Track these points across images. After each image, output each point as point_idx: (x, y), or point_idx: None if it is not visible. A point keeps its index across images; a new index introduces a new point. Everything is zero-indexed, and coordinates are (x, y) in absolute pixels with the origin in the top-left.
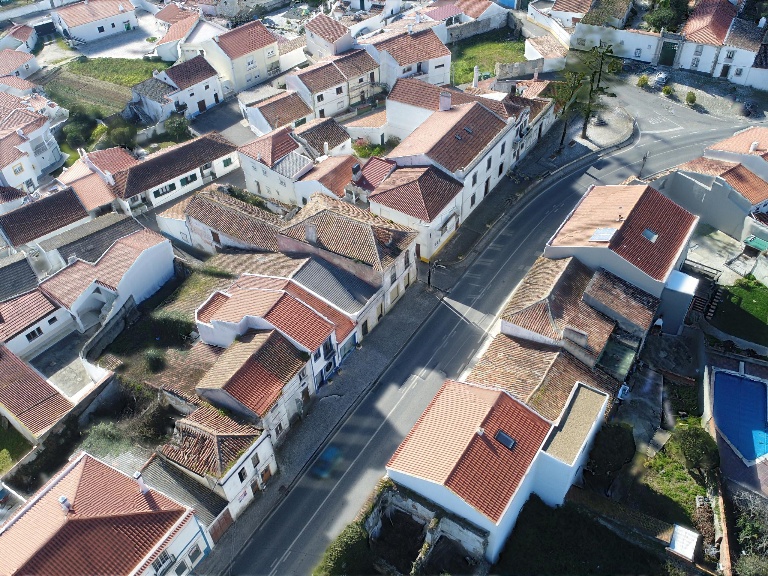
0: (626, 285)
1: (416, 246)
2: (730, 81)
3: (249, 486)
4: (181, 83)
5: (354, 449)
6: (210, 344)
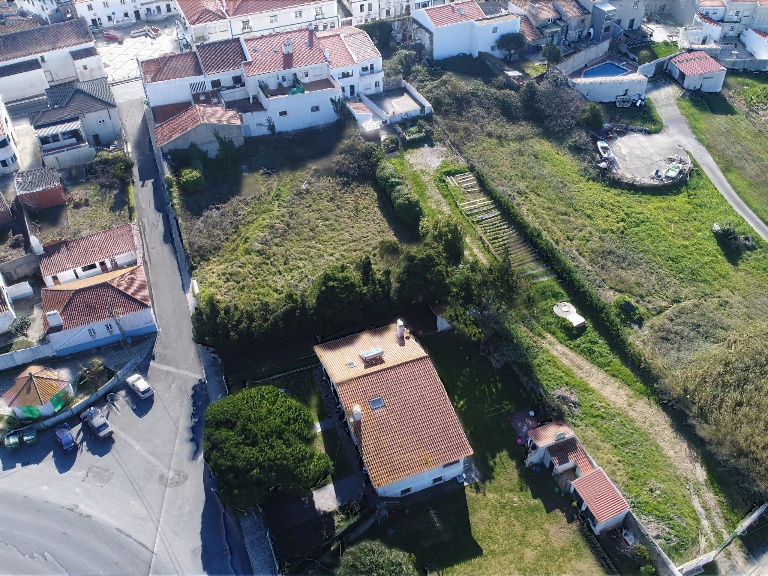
0: (579, 3)
1: None
2: None
3: (364, 19)
4: None
5: None
6: None
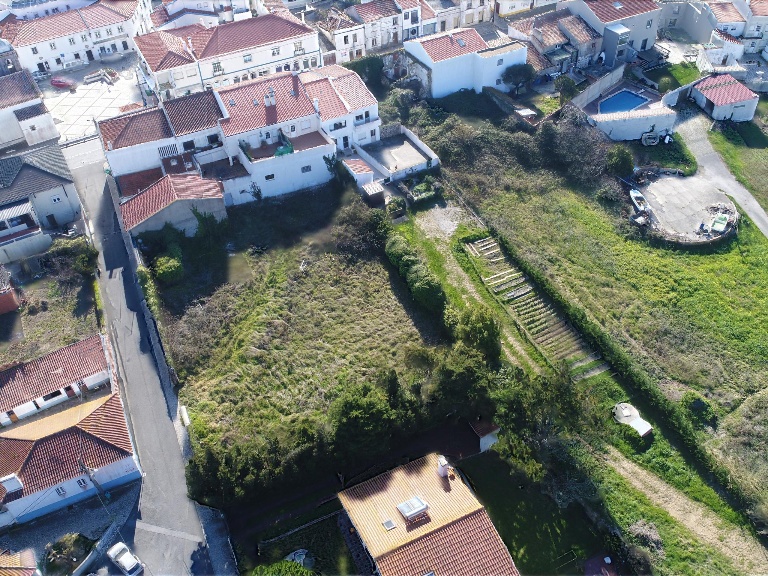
0: (587, 25)
1: (497, 4)
2: None
3: (349, 51)
4: None
5: None
6: None
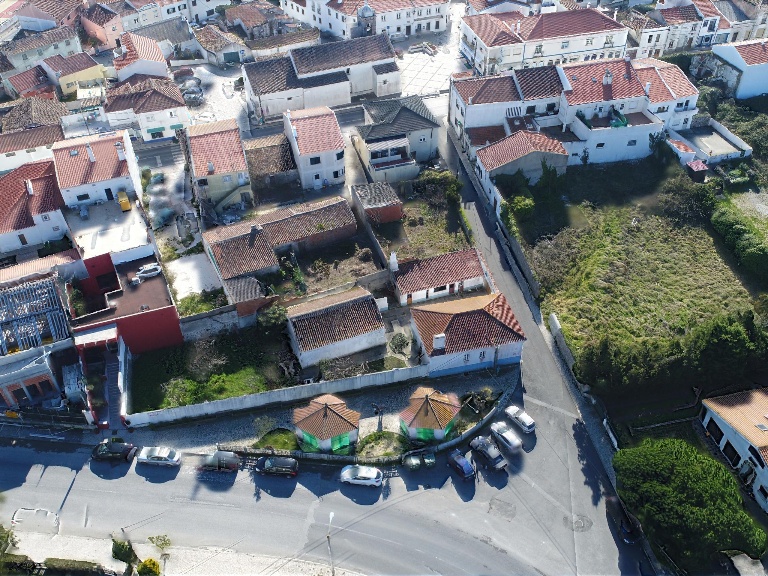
0: None
1: None
2: None
3: (649, 50)
4: None
5: None
6: None
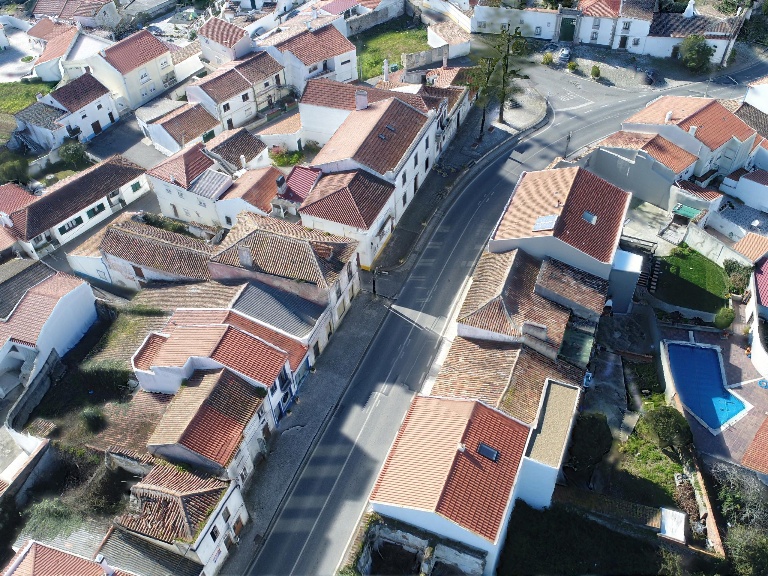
0: (574, 271)
1: None
2: (629, 51)
3: (222, 543)
4: (70, 105)
5: (327, 482)
6: (152, 392)
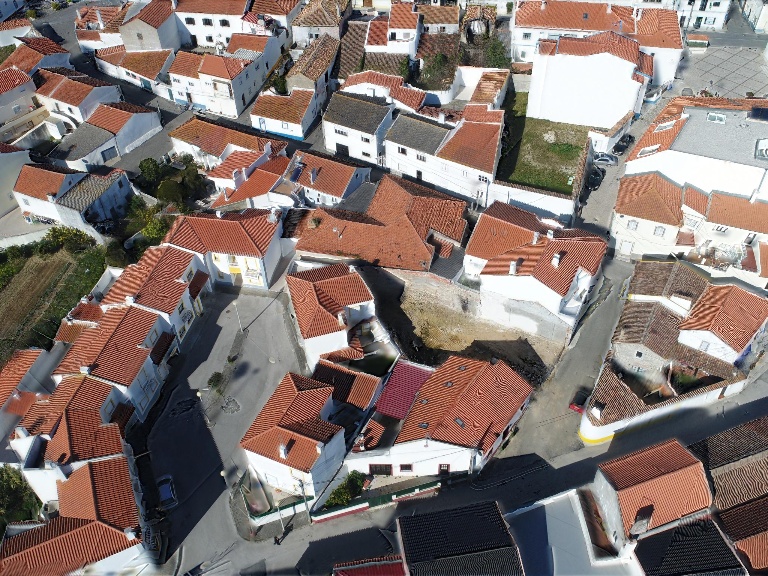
0: None
1: None
2: None
3: None
4: None
5: None
6: (418, 50)
